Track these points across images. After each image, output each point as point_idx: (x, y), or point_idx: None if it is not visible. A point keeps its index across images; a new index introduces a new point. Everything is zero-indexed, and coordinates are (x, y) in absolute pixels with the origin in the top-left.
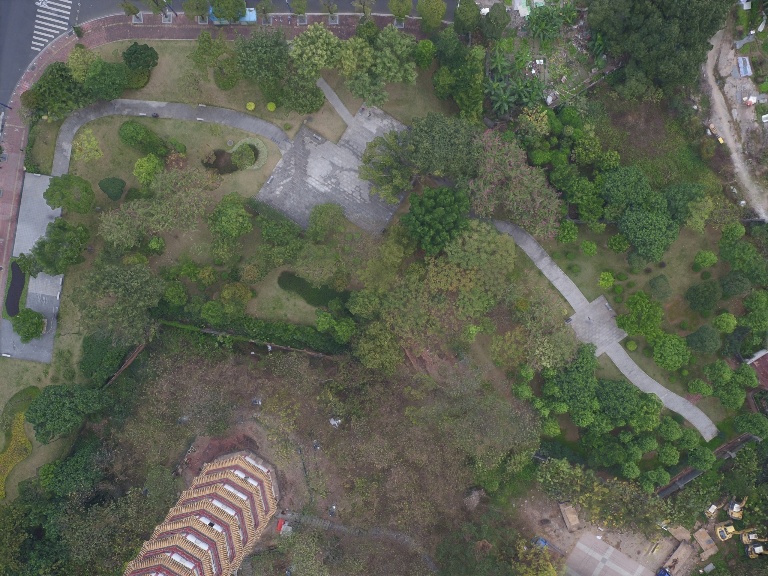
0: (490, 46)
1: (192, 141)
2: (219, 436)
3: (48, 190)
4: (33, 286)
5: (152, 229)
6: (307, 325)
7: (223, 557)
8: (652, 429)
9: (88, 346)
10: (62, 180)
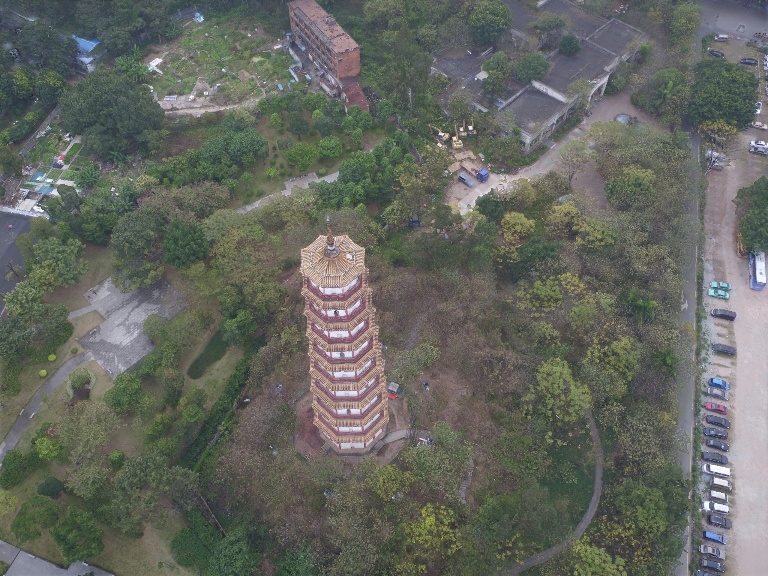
0: None
1: None
2: (302, 432)
3: (19, 530)
4: None
5: None
6: None
7: None
8: (373, 155)
9: (187, 559)
10: None
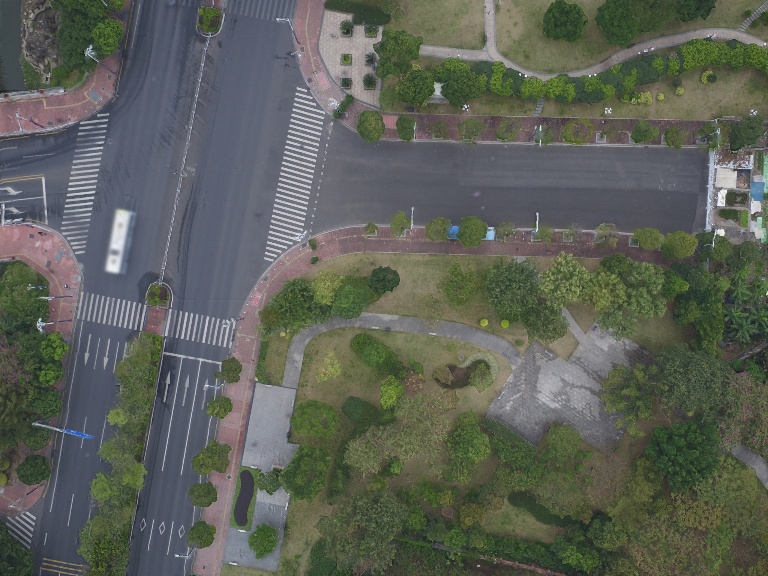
0: (725, 267)
1: (424, 355)
2: None
3: (298, 420)
4: (261, 495)
5: (397, 456)
6: (535, 541)
7: None
8: None
9: (317, 558)
10: (310, 408)
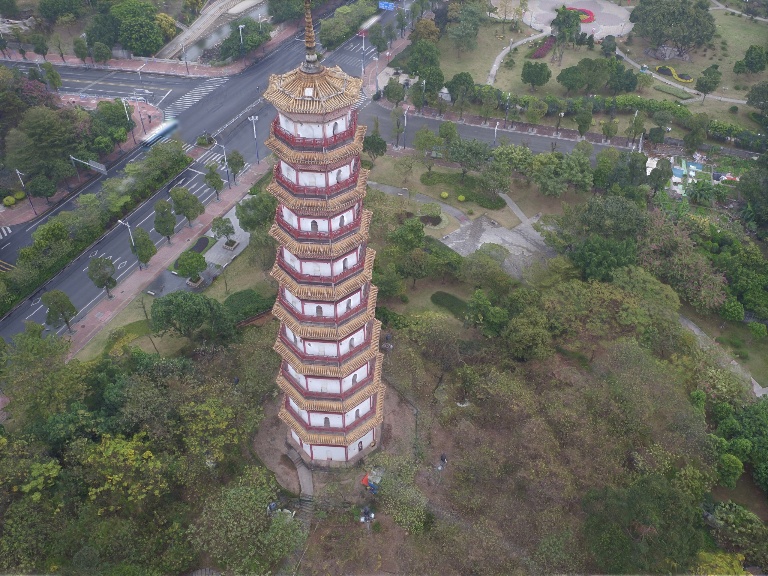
0: (652, 203)
1: None
2: None
3: None
4: (207, 256)
5: None
6: None
7: (367, 267)
8: None
9: (231, 300)
10: None
